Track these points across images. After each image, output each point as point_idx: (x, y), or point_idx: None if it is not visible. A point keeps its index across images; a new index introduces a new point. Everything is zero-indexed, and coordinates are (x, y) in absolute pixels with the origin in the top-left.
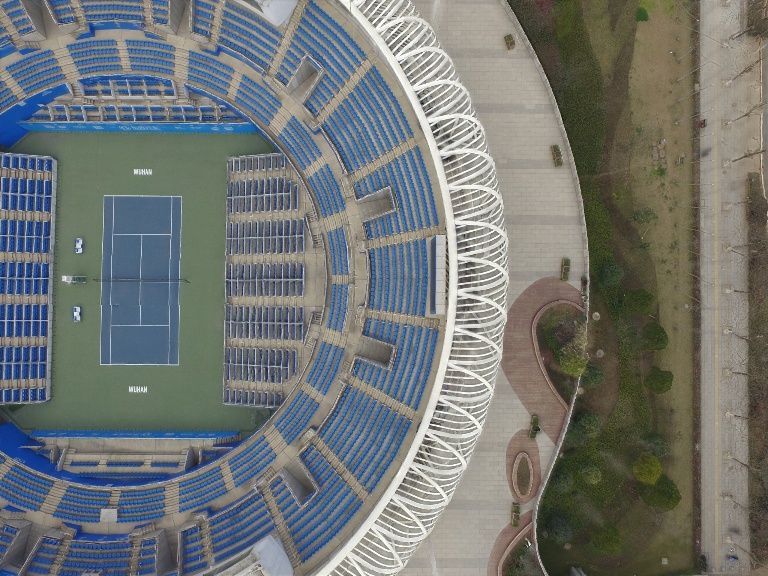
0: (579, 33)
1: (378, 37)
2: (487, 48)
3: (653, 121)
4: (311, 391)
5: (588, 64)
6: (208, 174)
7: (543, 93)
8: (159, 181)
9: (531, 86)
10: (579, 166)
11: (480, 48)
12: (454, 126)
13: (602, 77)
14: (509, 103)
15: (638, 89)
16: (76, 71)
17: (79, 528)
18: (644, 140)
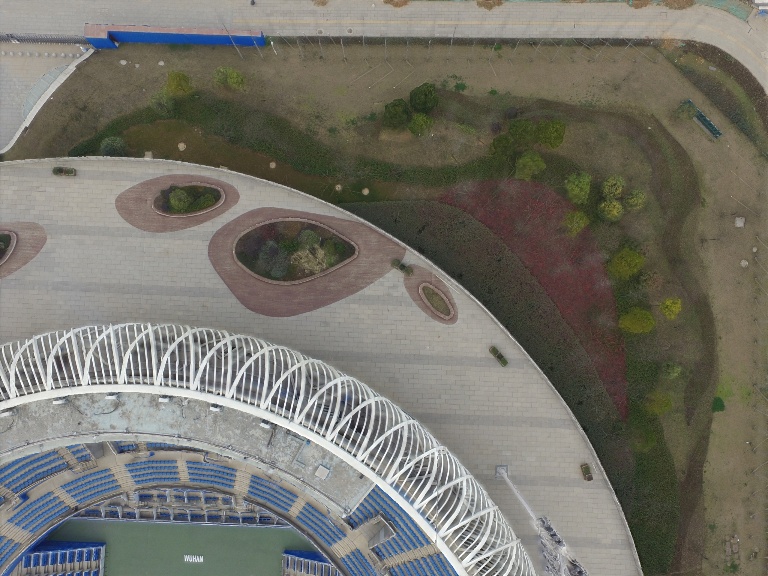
0: (653, 429)
1: (465, 575)
2: (562, 476)
3: (727, 516)
4: None
5: (662, 461)
6: (261, 563)
7: (620, 527)
8: (210, 569)
9: (607, 519)
10: (649, 566)
11: (555, 476)
12: None
13: (676, 474)
14: (584, 537)
15: (712, 484)
16: (132, 481)
17: None
18: (717, 537)
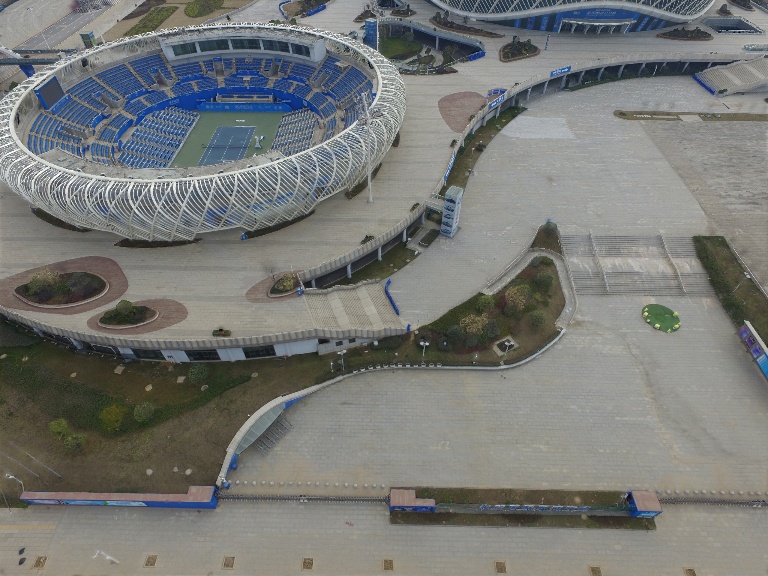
0: None
1: None
2: None
3: None
4: (147, 104)
5: None
6: None
7: None
8: None
9: None
10: None
11: None
12: (1, 111)
13: None
14: None
15: None
16: None
17: (259, 76)
18: None
